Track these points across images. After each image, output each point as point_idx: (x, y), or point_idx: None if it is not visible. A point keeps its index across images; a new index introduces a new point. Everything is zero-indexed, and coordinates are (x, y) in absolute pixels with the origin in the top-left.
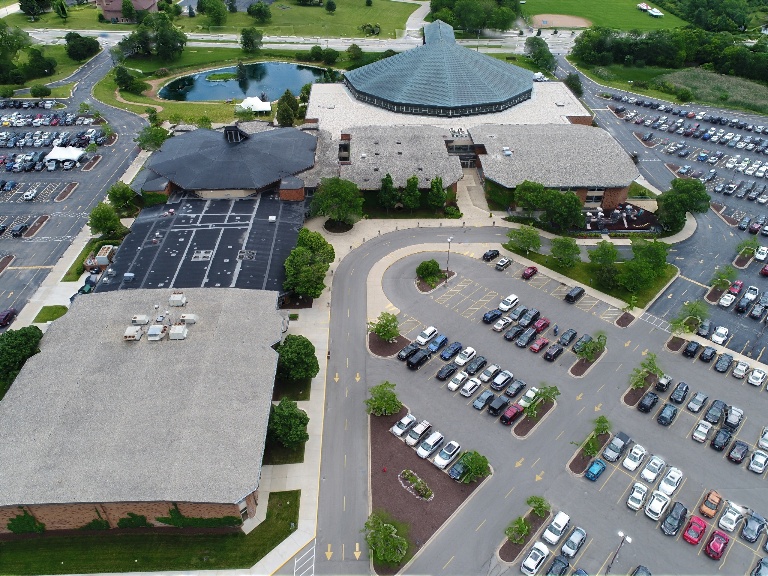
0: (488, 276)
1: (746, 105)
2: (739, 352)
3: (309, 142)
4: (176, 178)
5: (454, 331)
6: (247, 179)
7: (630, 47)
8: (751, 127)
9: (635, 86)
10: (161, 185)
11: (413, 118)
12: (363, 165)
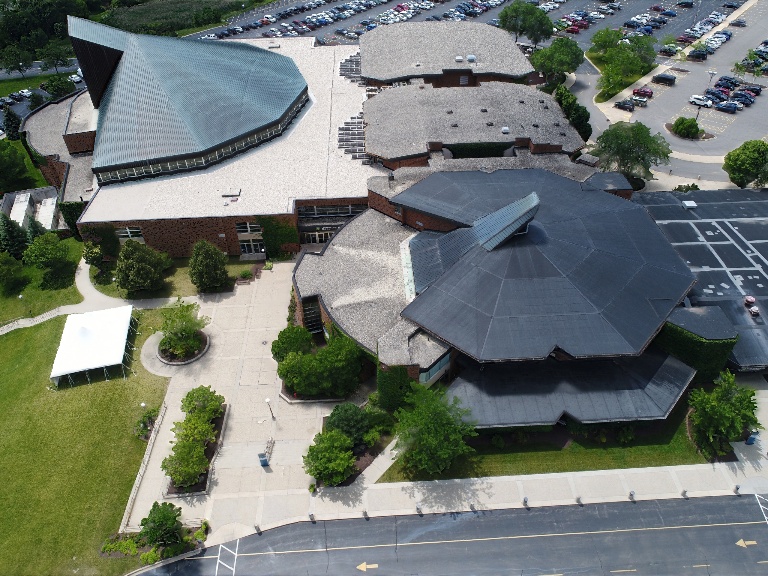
0: (659, 110)
1: (229, 9)
2: (685, 47)
3: (462, 175)
4: (670, 295)
5: (760, 124)
6: (629, 214)
7: (36, 17)
8: (308, 6)
9: (165, 32)
10: (703, 314)
11: (306, 123)
12: (529, 133)
